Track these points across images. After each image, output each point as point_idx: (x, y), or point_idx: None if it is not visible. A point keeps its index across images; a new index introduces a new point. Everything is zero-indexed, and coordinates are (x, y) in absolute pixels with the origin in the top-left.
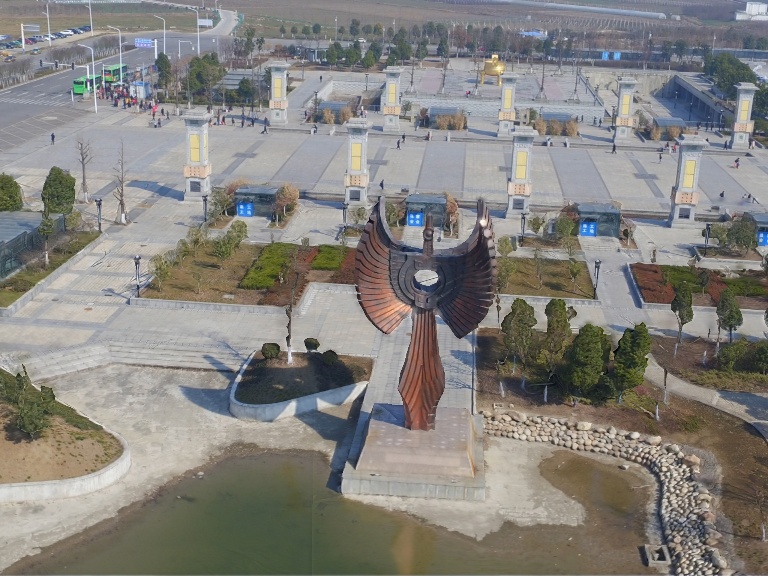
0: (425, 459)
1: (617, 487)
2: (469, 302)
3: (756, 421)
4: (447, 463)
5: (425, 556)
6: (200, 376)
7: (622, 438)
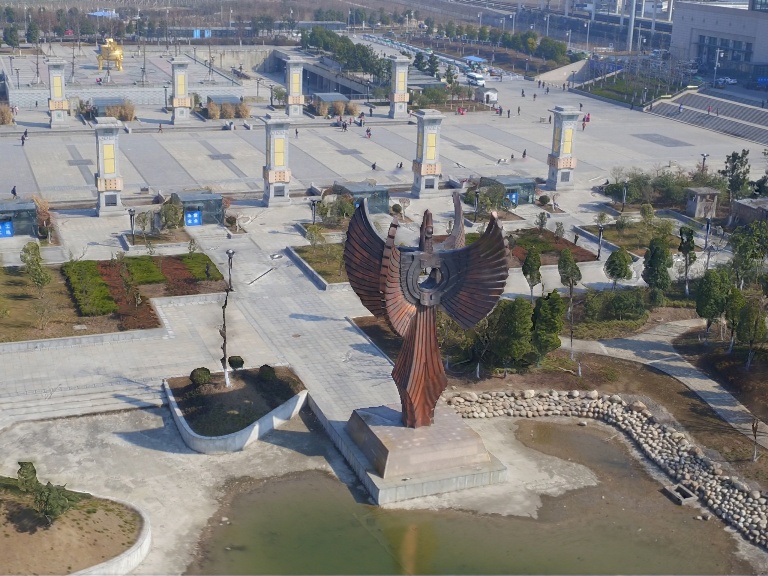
0: (446, 453)
1: (593, 443)
2: (476, 293)
3: (651, 362)
4: (466, 453)
5: (507, 545)
6: (125, 418)
7: (566, 398)
